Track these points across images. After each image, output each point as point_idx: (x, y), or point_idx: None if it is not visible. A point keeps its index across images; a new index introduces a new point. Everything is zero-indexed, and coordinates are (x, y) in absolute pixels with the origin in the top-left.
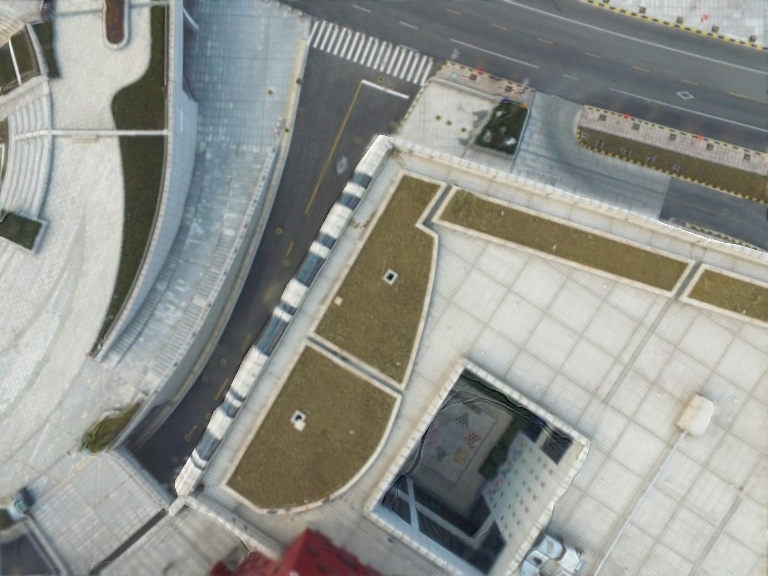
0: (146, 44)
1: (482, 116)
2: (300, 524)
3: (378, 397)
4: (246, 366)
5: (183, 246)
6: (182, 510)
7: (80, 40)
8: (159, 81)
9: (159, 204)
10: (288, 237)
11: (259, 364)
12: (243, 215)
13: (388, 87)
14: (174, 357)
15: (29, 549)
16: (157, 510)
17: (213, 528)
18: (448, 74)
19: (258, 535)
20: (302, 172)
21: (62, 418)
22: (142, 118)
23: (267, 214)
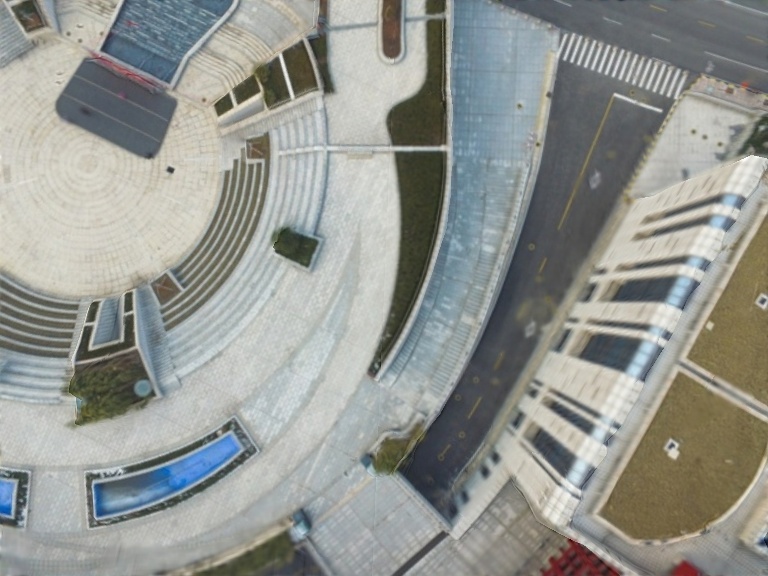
0: (422, 58)
1: (739, 130)
2: (672, 555)
3: (753, 425)
4: (619, 393)
5: (445, 263)
6: (465, 533)
7: (354, 55)
8: (437, 96)
9: (438, 221)
10: (541, 253)
11: (636, 391)
12: (503, 231)
13: (640, 100)
14: (450, 376)
15: (312, 572)
16: (436, 532)
17: (493, 551)
18: (704, 87)
19: (633, 566)
20: (554, 187)
21: (338, 438)
22: (419, 134)
23: (519, 230)
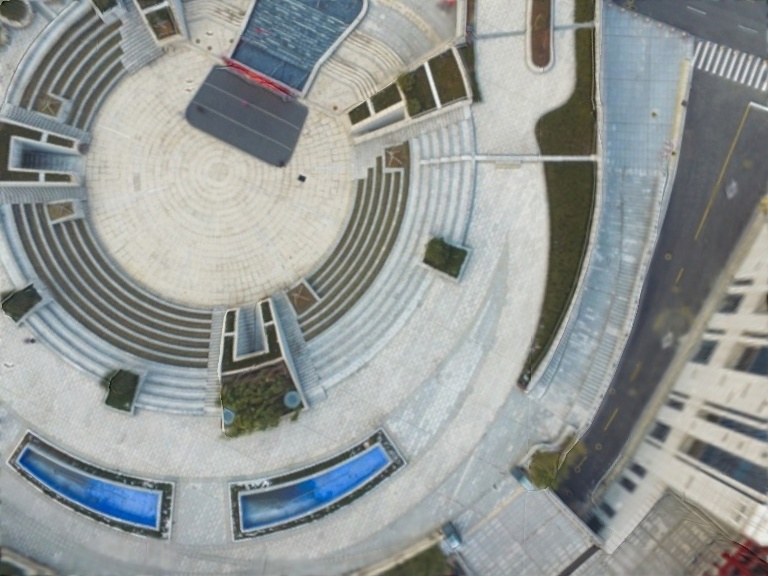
0: (570, 67)
1: None
2: None
3: None
4: None
5: (586, 273)
6: None
7: (501, 63)
8: (587, 105)
9: (589, 232)
10: (678, 263)
11: None
12: (643, 241)
13: None
14: (598, 389)
15: None
16: (587, 547)
17: (644, 566)
18: None
19: None
20: (691, 196)
21: (487, 451)
22: (569, 143)
23: None
